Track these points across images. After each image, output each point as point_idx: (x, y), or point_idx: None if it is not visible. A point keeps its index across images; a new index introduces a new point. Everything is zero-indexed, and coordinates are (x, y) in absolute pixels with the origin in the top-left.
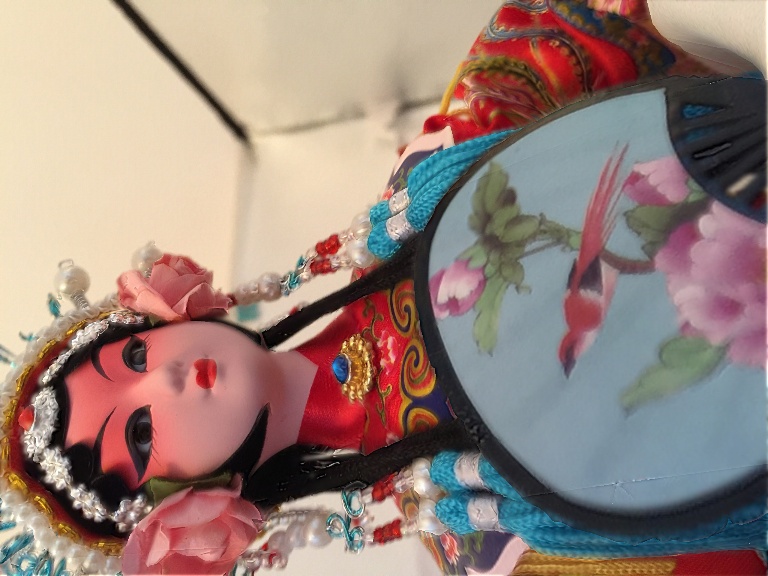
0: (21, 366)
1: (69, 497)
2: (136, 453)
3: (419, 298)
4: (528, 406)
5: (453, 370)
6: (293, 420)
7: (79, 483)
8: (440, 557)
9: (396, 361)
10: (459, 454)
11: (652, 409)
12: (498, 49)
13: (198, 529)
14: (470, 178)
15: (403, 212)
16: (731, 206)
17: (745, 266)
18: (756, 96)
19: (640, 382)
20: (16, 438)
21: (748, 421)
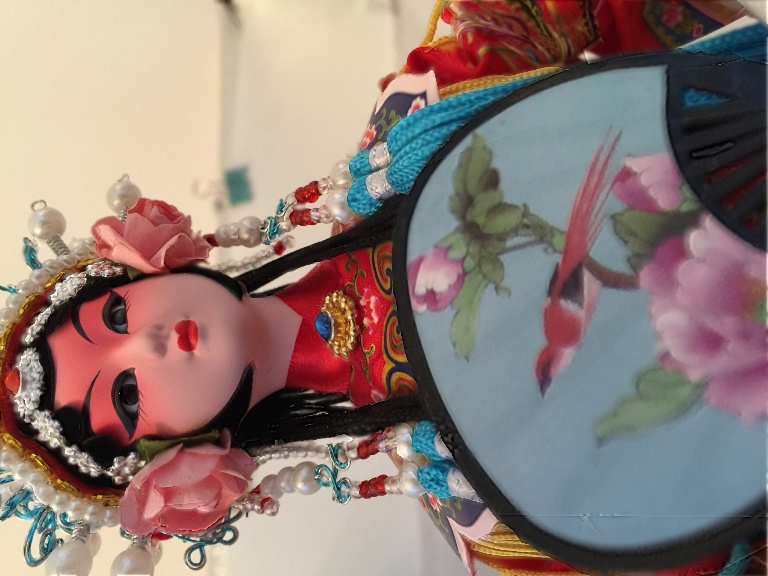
0: None
1: (64, 453)
2: (124, 415)
3: (396, 285)
4: (502, 422)
5: (429, 371)
6: (280, 369)
7: (72, 443)
8: (425, 501)
9: (379, 322)
10: None
11: (625, 443)
12: None
13: (190, 485)
14: (451, 150)
15: (383, 172)
16: (726, 223)
17: (733, 296)
18: (767, 88)
19: (615, 412)
20: (6, 397)
21: (719, 469)
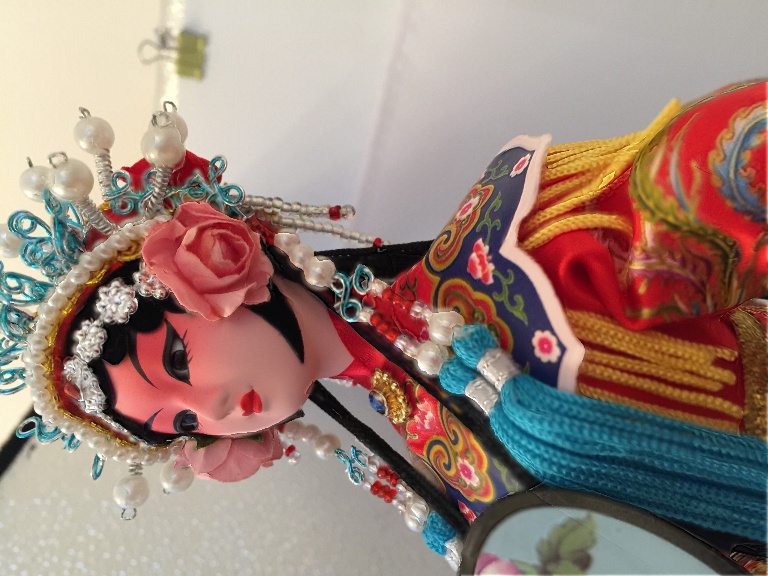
0: (45, 320)
1: None
2: None
3: (467, 555)
4: None
5: None
6: None
7: (133, 434)
8: None
9: (429, 431)
10: (453, 530)
11: None
12: (719, 215)
13: None
14: (562, 507)
15: (488, 407)
16: None
17: None
18: None
19: None
20: (60, 382)
21: None
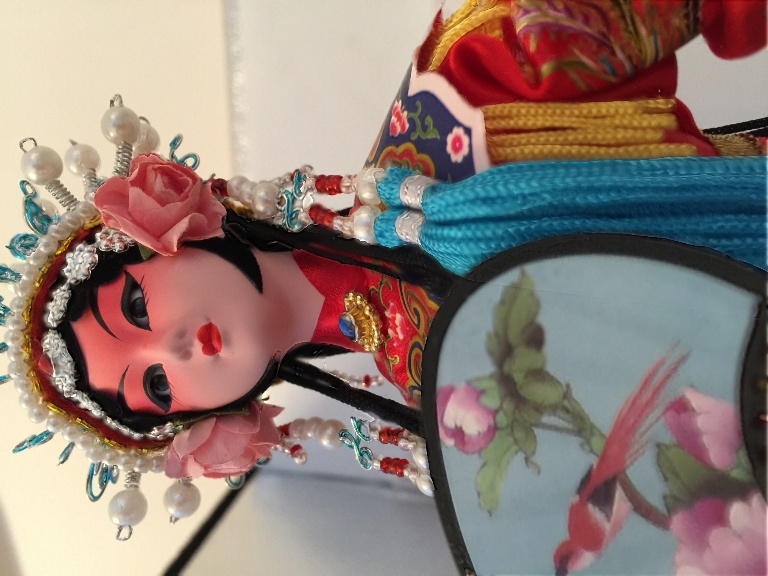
0: (21, 296)
1: None
2: (158, 401)
3: (425, 403)
4: None
5: (453, 505)
6: (303, 337)
7: (113, 418)
8: None
9: (404, 340)
10: None
11: None
12: None
13: None
14: (495, 278)
15: (415, 229)
16: None
17: None
18: None
19: None
20: None
21: None
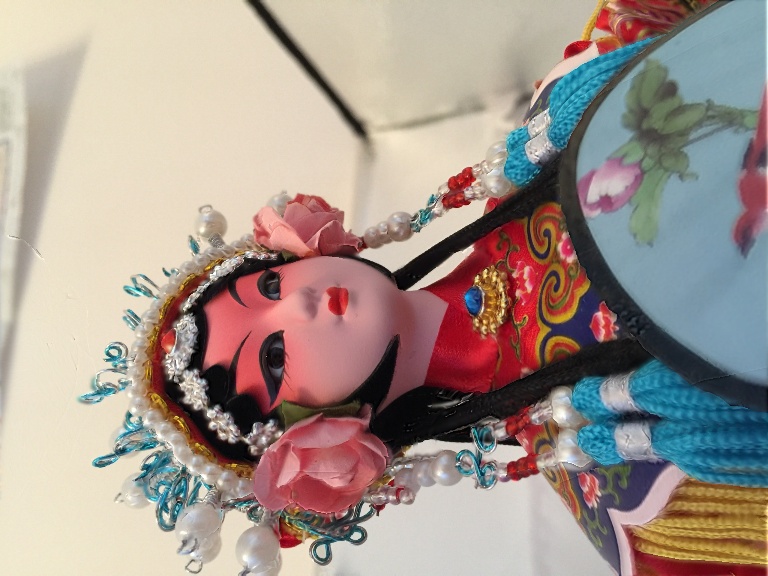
0: (164, 297)
1: (205, 419)
2: (269, 376)
3: (566, 201)
4: (697, 291)
5: (606, 266)
6: (422, 358)
7: (215, 403)
8: (578, 501)
9: (533, 290)
10: (605, 378)
11: None
12: None
13: (327, 453)
14: (623, 79)
15: (544, 131)
16: None
17: None
18: None
19: None
20: (158, 362)
21: None
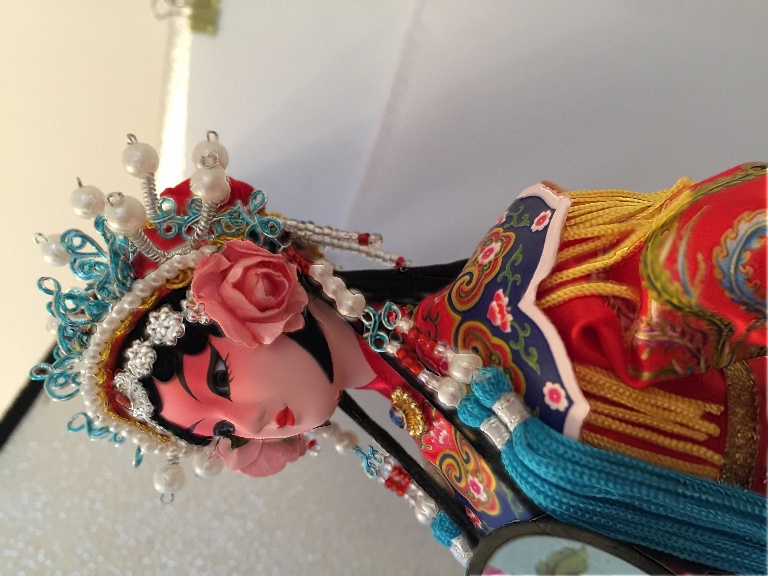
0: (99, 338)
1: None
2: None
3: (474, 566)
4: None
5: None
6: None
7: (174, 435)
8: None
9: (443, 445)
10: (459, 529)
11: None
12: (718, 302)
13: None
14: (561, 538)
15: (500, 444)
16: None
17: None
18: None
19: None
20: (111, 390)
21: None
